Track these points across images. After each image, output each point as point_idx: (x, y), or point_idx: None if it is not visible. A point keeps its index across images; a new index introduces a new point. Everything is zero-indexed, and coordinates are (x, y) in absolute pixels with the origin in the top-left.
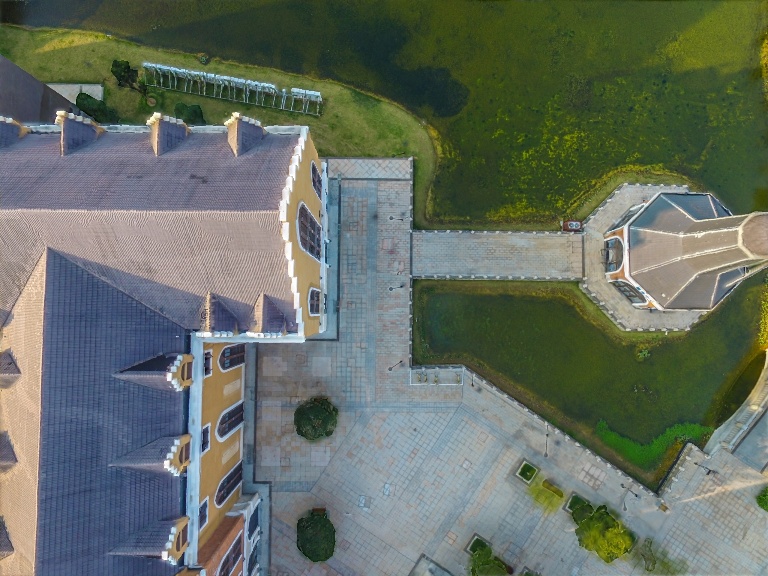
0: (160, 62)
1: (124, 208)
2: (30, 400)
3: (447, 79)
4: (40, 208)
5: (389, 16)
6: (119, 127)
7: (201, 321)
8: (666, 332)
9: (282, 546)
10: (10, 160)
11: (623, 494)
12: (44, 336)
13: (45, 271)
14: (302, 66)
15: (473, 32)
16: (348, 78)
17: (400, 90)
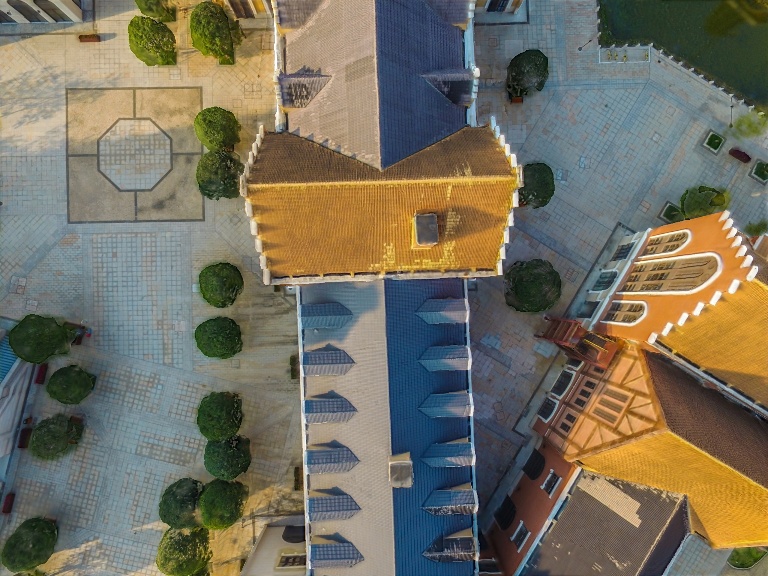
0: None
1: None
2: None
3: None
4: None
5: None
6: None
7: None
8: None
9: None
10: None
11: None
12: None
13: None
14: None
15: None
16: None
17: None
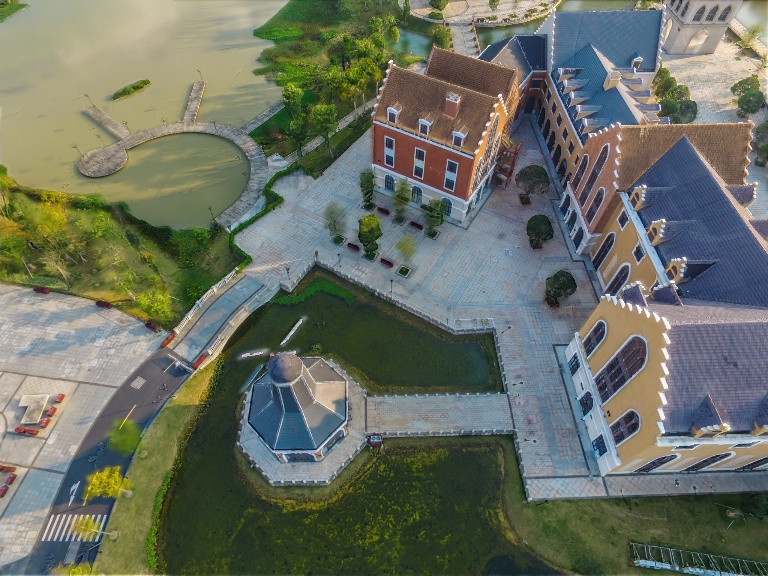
0: None
1: None
2: None
3: None
4: None
5: None
6: None
7: None
8: None
9: (554, 231)
10: None
11: (340, 262)
12: None
13: None
14: None
15: None
16: None
17: None
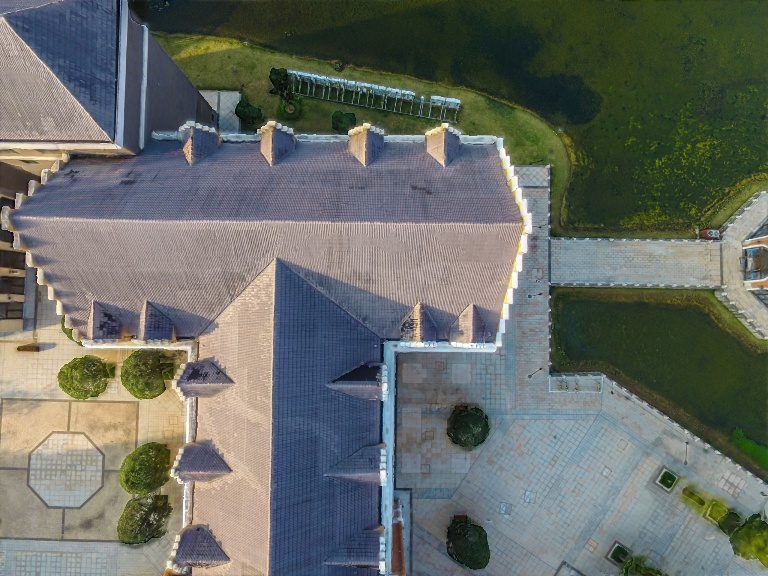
0: (296, 69)
1: (367, 220)
2: (253, 410)
3: (580, 87)
4: (284, 220)
5: (521, 23)
6: (309, 136)
7: (403, 331)
8: None
9: (423, 553)
10: (222, 170)
11: (763, 502)
12: (274, 347)
13: (274, 282)
14: (435, 73)
15: (605, 40)
16: (481, 85)
17: (533, 97)
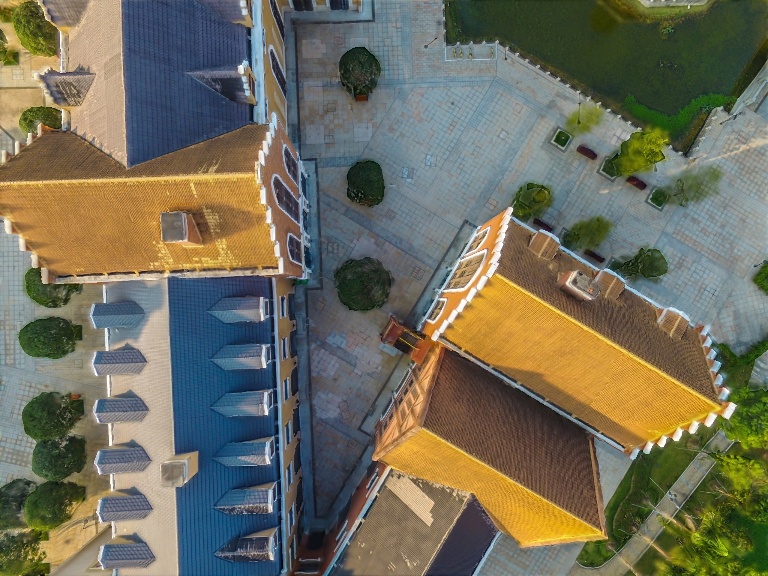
0: None
1: None
2: None
3: None
4: None
5: None
6: None
7: None
8: (689, 5)
9: (331, 219)
10: None
11: None
12: None
13: None
14: None
15: None
16: None
17: None
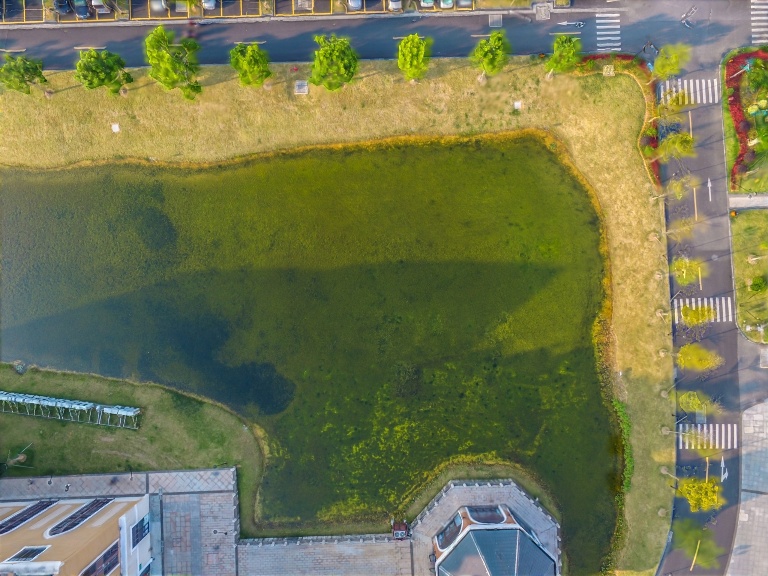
0: None
1: None
2: None
3: (272, 375)
4: None
5: (210, 311)
6: None
7: None
8: None
9: None
10: None
11: None
12: None
13: None
14: (122, 369)
15: (297, 323)
16: (170, 379)
17: (224, 389)
